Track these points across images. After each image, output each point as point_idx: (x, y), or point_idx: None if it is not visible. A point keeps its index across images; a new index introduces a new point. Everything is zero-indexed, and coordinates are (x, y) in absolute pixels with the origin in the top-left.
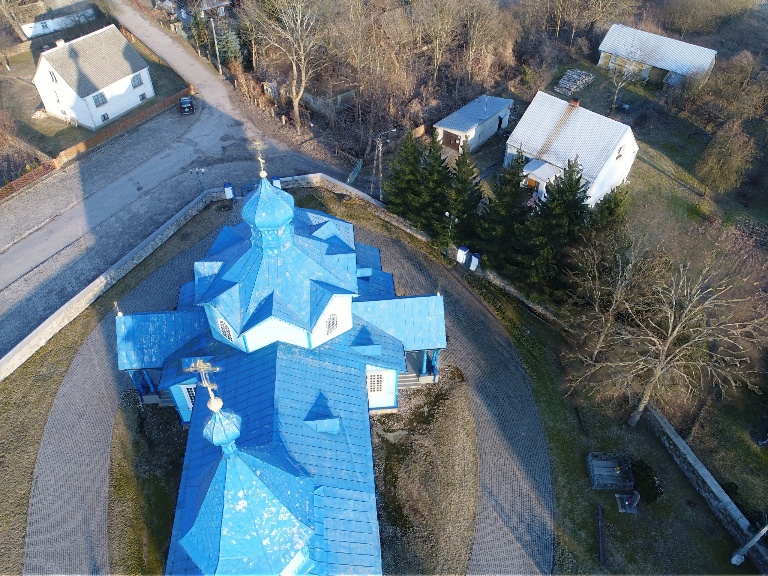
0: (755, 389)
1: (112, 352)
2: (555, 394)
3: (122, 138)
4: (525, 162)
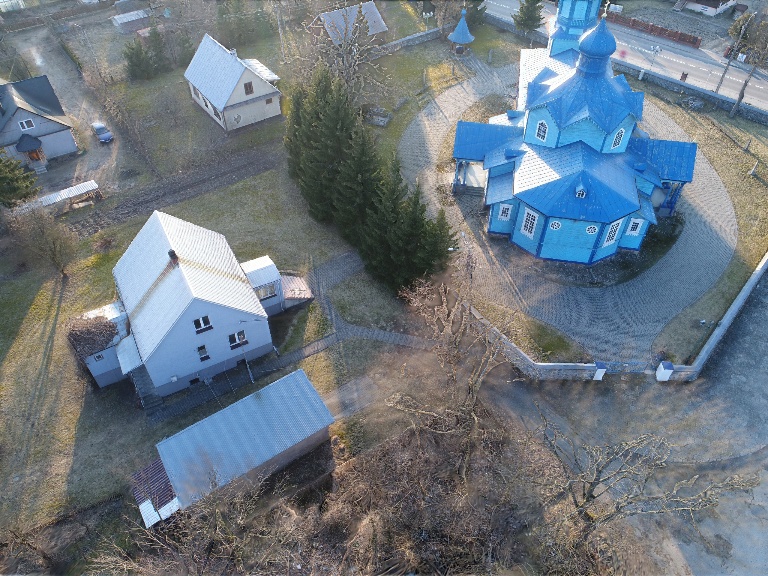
0: (303, 72)
1: (708, 224)
2: (381, 151)
3: None
4: (348, 139)
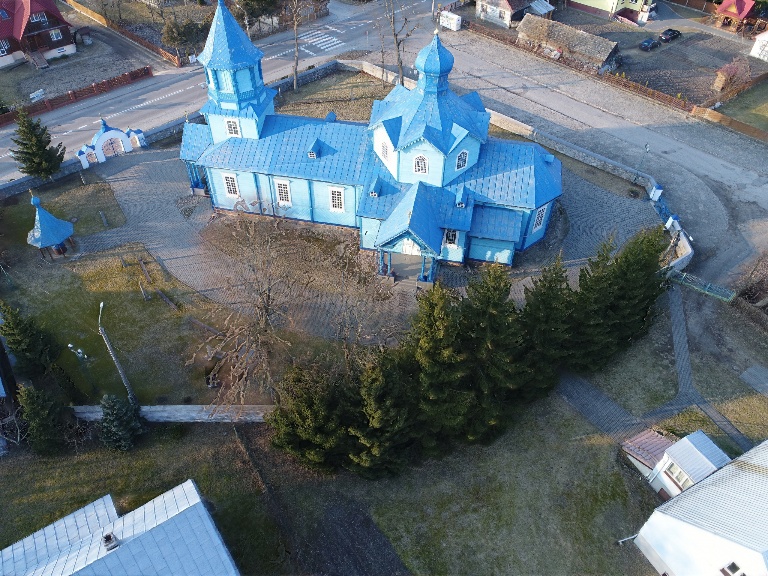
0: None
1: None
2: None
3: (756, 143)
4: (567, 290)
